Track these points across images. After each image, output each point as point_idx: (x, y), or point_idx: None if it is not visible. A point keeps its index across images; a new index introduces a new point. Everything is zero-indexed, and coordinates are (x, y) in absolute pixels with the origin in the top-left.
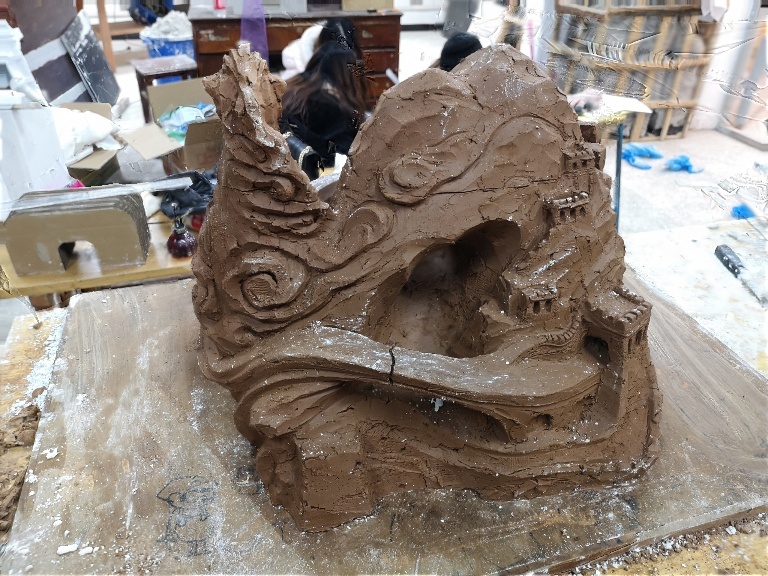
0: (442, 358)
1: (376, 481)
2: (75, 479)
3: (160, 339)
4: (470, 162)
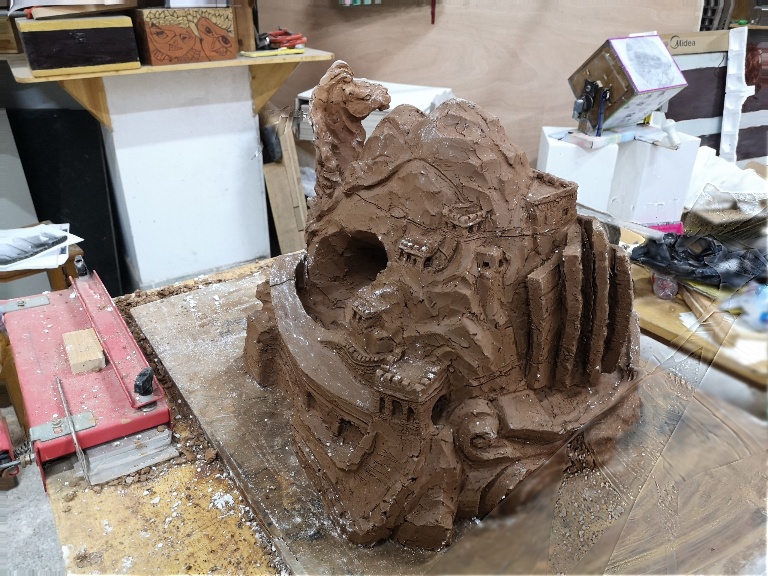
0: (299, 304)
1: None
2: None
3: None
4: (377, 180)
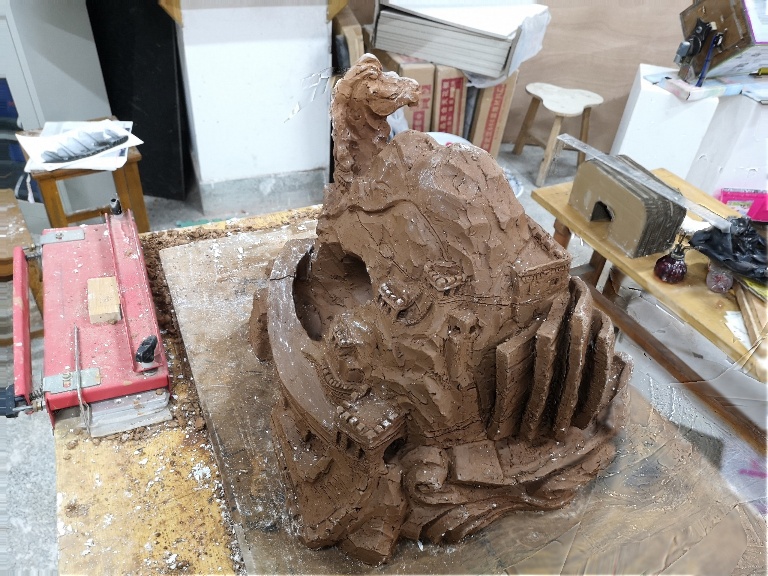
0: (292, 305)
1: None
2: (285, 241)
3: None
4: (375, 208)
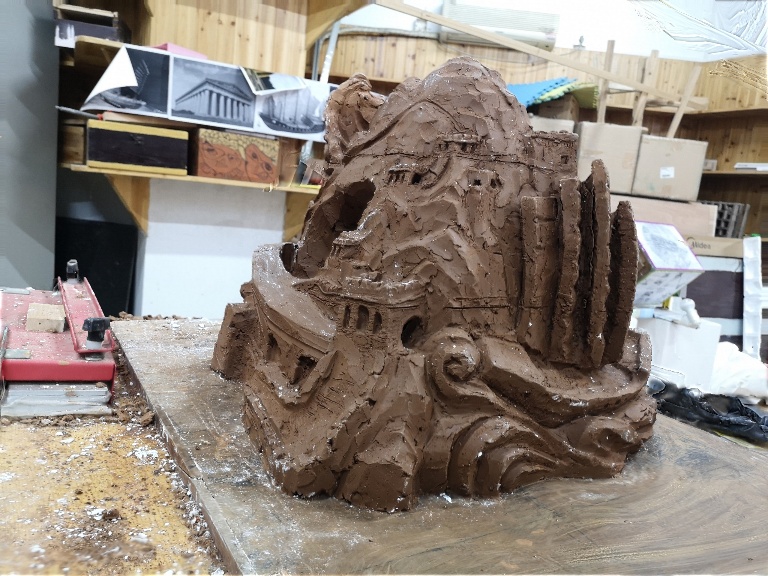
0: (279, 263)
1: (245, 364)
2: None
3: None
4: None
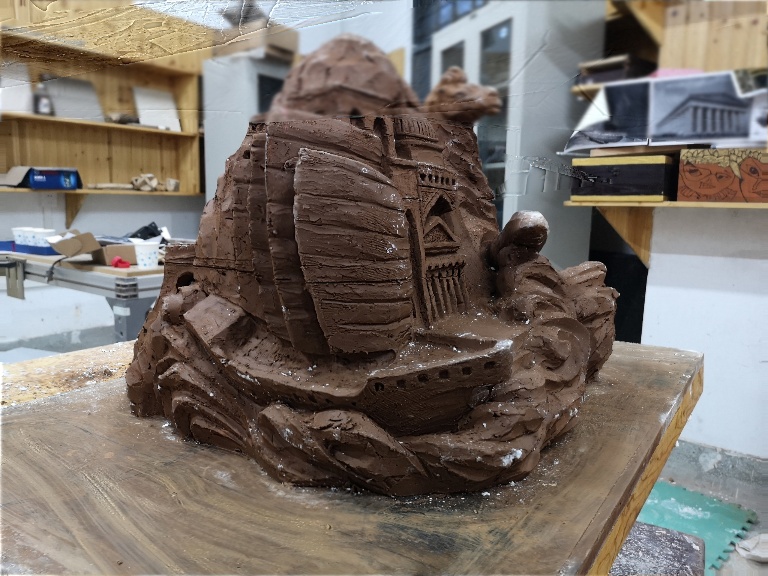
0: None
1: None
2: None
3: None
4: None
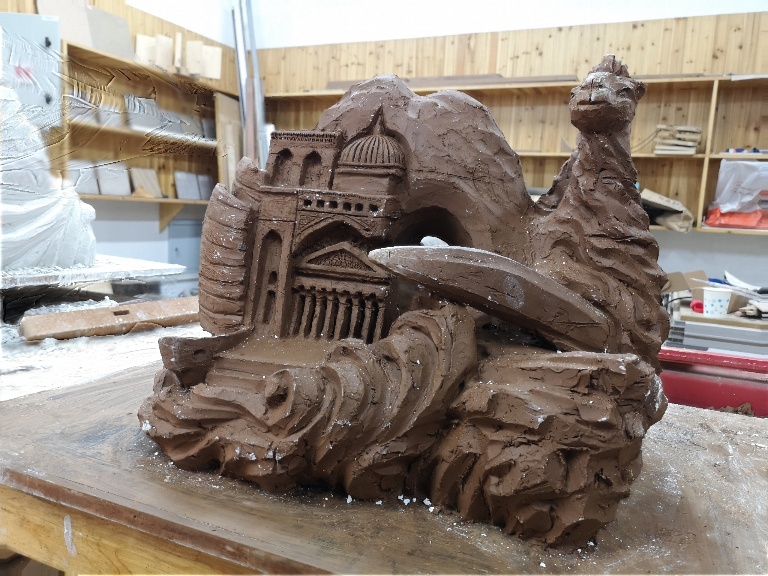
0: None
1: None
2: None
3: (752, 570)
4: None
